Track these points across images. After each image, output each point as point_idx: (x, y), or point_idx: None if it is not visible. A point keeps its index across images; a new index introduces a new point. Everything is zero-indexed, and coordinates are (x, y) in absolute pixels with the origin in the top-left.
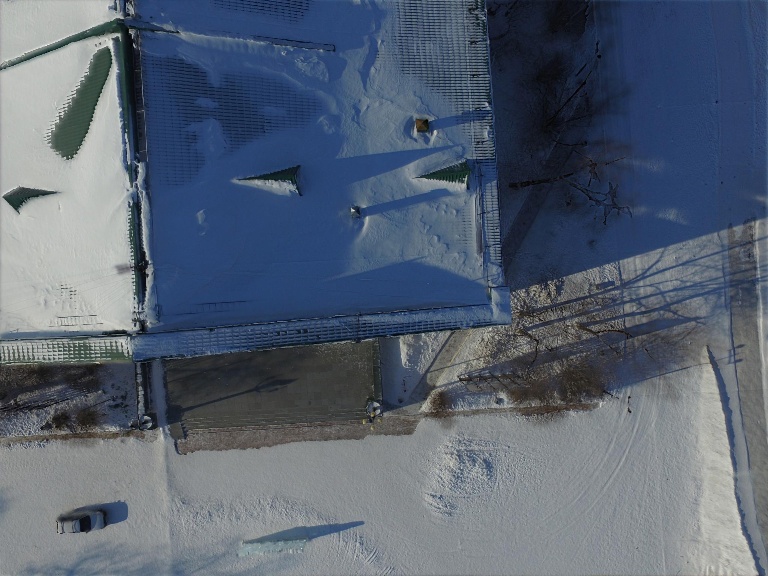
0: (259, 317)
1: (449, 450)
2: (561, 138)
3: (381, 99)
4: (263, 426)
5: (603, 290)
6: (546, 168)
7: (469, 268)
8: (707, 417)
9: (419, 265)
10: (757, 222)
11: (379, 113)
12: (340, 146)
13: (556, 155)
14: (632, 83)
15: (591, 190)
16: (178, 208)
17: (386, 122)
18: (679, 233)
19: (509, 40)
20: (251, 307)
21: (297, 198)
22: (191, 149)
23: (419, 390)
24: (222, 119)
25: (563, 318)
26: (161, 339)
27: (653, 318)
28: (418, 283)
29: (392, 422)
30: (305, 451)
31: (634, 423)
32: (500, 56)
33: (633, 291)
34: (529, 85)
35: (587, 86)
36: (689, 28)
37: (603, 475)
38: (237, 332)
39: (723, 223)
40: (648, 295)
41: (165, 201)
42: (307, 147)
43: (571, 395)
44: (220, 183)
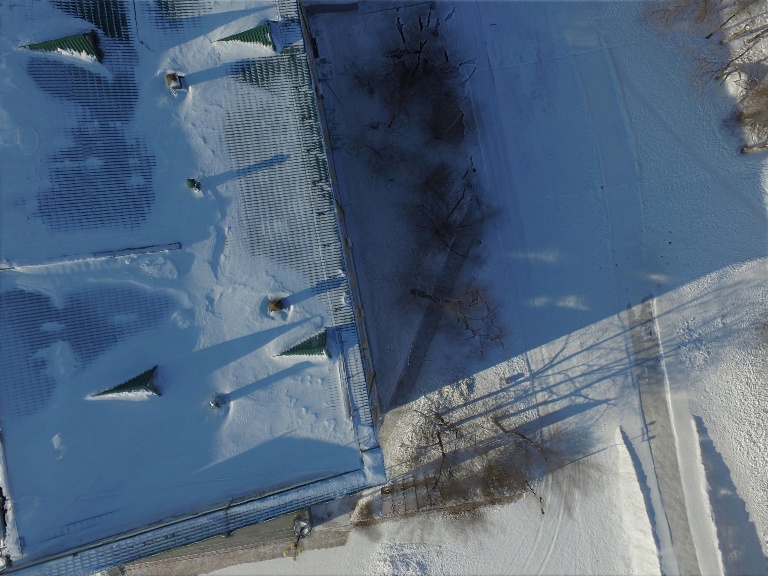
0: (128, 525)
1: (382, 557)
2: (457, 239)
3: (234, 285)
4: (198, 554)
5: (514, 383)
6: (445, 269)
7: (340, 434)
8: (627, 497)
9: (289, 439)
10: (654, 299)
11: (233, 299)
12: (197, 338)
13: (454, 256)
14: (519, 178)
15: (491, 286)
16: (32, 437)
17: (241, 306)
18: (581, 318)
19: (393, 153)
20: (119, 516)
21: (156, 399)
22: (41, 376)
23: (347, 501)
24: (71, 339)
25: (478, 415)
26: (22, 575)
27: (565, 404)
28: (290, 457)
29: (324, 535)
30: (242, 574)
31: (559, 509)
32: (386, 169)
33: (543, 380)
34: (416, 197)
35: (476, 186)
36: (568, 118)
37: (535, 564)
38: (101, 552)
39: (622, 304)
40: (558, 383)
41: (18, 433)
42: (162, 346)
43: (494, 490)
44: (74, 403)
